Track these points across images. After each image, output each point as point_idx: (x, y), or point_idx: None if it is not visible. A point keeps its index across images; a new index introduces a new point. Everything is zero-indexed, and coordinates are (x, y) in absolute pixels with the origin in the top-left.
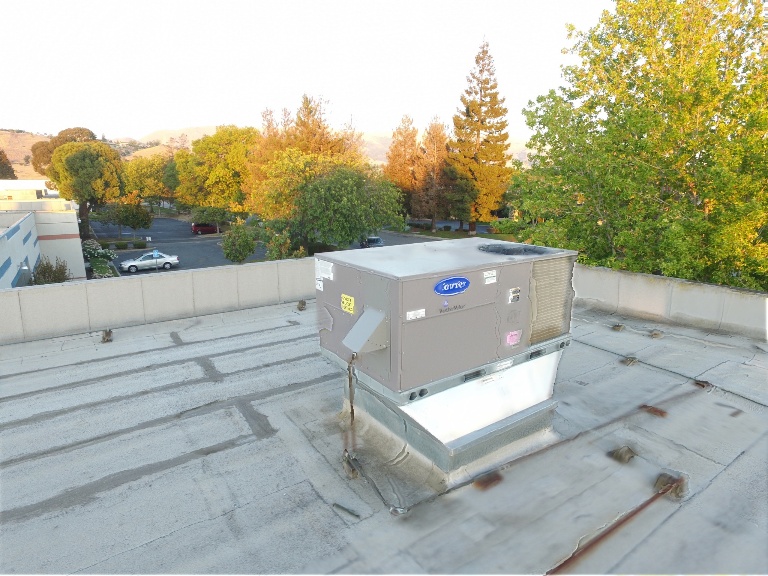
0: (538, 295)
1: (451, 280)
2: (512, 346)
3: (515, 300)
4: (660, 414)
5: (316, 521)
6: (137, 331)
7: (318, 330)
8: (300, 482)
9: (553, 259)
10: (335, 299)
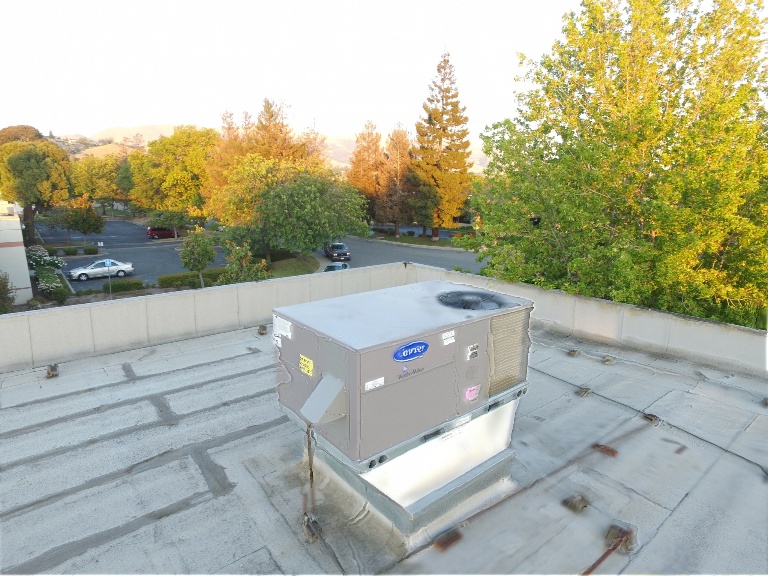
0: (496, 349)
1: (410, 346)
2: (471, 401)
3: (473, 356)
4: (612, 454)
5: None
6: (86, 363)
7: None
8: (258, 550)
9: (510, 313)
10: (293, 358)
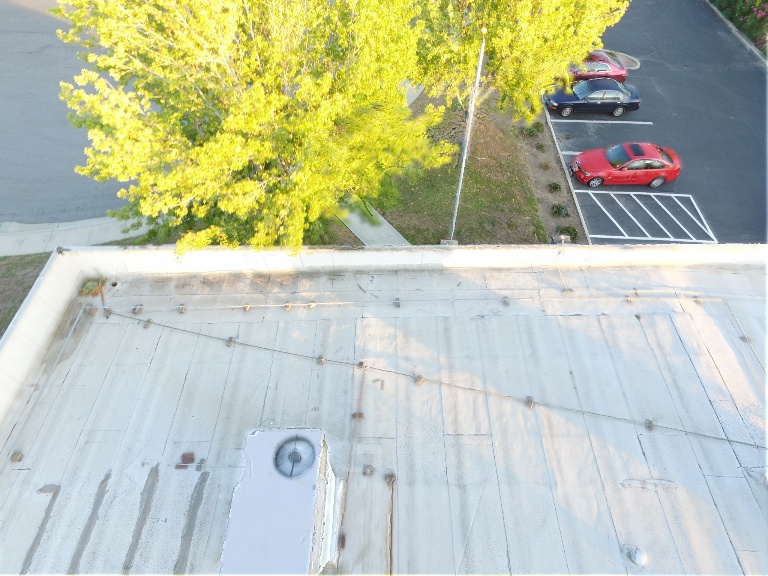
0: None
1: None
2: None
3: None
4: (361, 418)
5: None
6: None
7: (92, 483)
8: None
9: (321, 456)
10: None
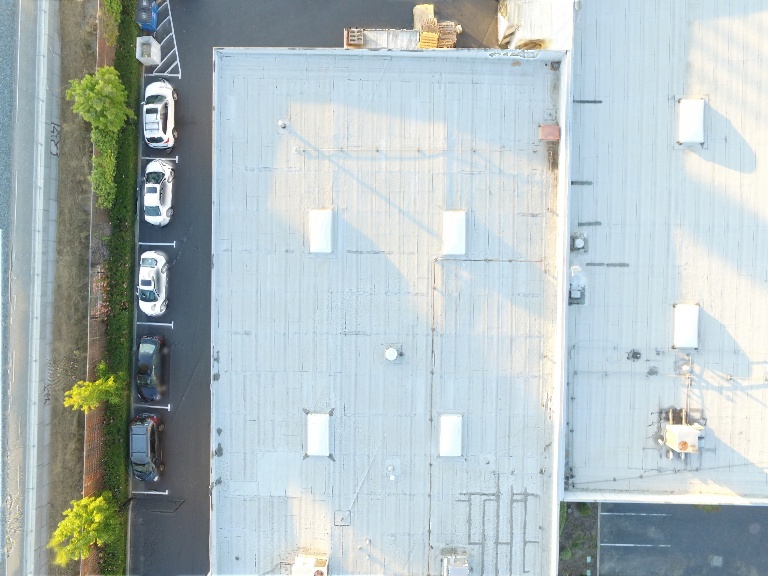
0: None
1: None
2: None
3: None
4: None
5: (448, 541)
6: None
7: (514, 574)
8: (455, 543)
9: None
10: None
